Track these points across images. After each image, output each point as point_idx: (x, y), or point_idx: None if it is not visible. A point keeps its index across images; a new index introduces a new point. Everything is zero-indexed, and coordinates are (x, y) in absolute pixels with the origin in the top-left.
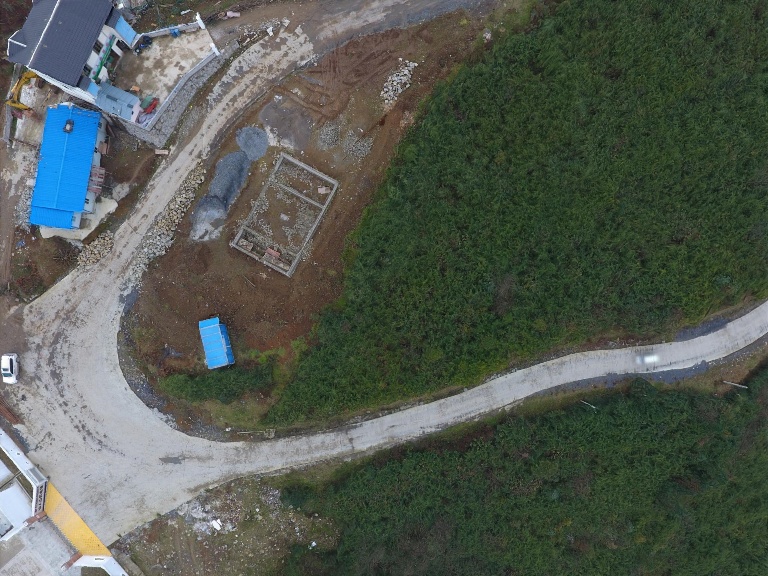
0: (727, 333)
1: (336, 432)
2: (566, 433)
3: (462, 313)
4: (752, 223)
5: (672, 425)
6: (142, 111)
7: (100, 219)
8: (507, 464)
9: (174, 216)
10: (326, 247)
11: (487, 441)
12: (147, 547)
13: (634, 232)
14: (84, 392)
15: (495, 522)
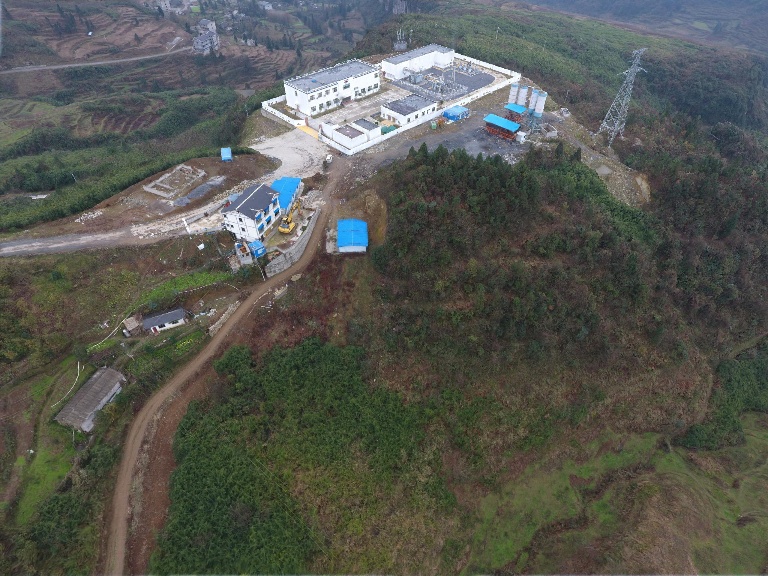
0: None
1: None
2: None
3: None
4: None
5: None
6: None
7: None
8: None
9: None
10: None
11: None
12: None
13: None
14: None
15: None
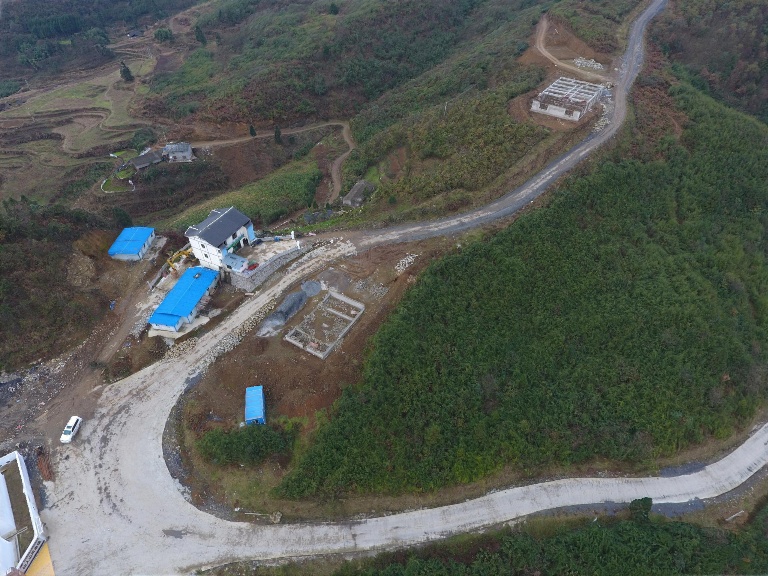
0: (709, 475)
1: (340, 525)
2: (575, 549)
3: (456, 408)
4: (679, 372)
5: (686, 552)
6: (247, 269)
7: (194, 327)
8: None
9: (247, 327)
10: (353, 341)
11: (494, 553)
12: None
13: (587, 370)
14: (122, 456)
15: None
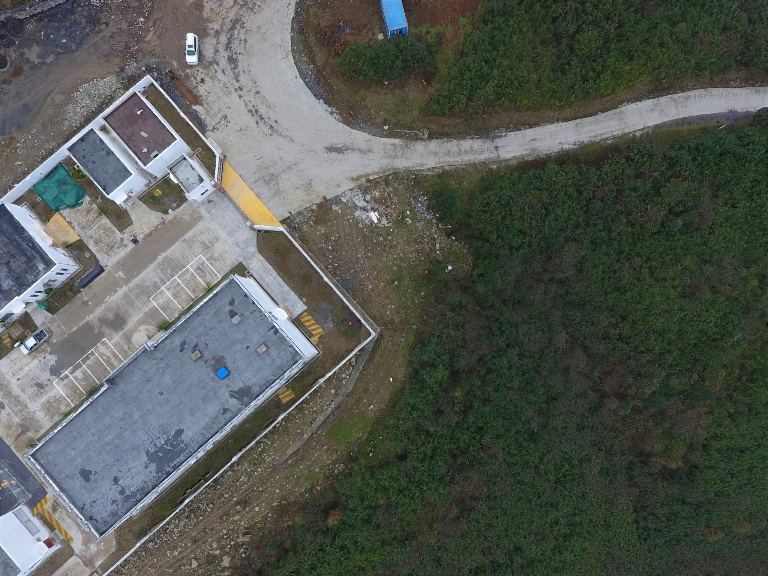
0: None
1: (483, 139)
2: (696, 153)
3: (612, 9)
4: None
5: None
6: None
7: None
8: (639, 183)
9: None
10: None
11: (621, 159)
12: (313, 228)
13: None
14: (258, 78)
15: (617, 260)
